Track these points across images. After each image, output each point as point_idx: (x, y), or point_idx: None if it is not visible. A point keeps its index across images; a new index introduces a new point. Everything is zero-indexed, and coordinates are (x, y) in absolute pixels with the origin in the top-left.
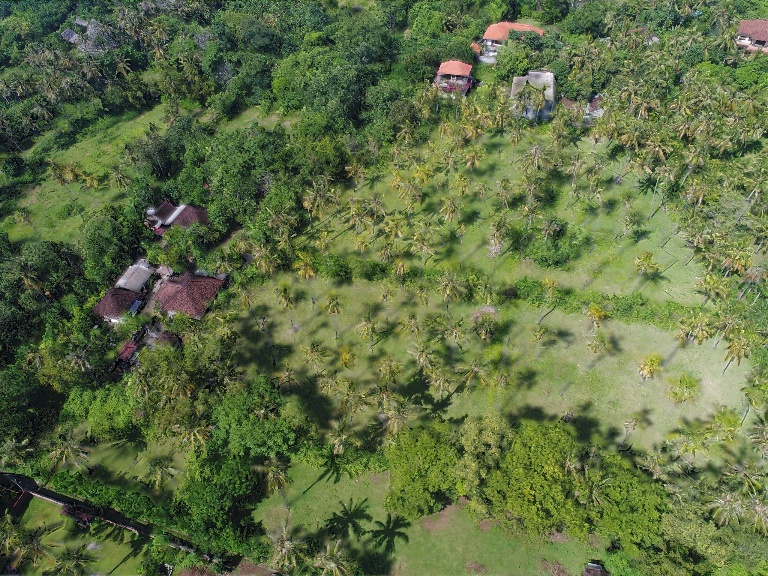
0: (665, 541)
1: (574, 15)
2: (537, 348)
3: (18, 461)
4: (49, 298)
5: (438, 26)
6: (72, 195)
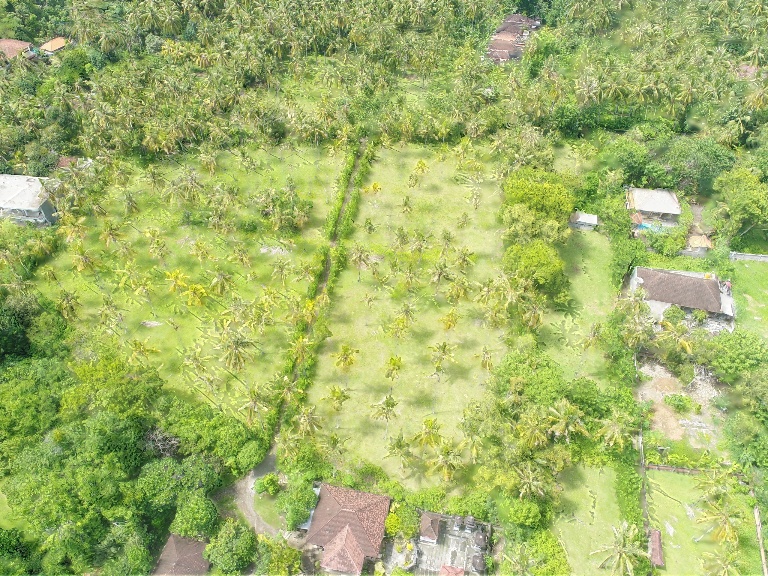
0: None
1: None
2: (390, 232)
3: None
4: None
5: None
6: None
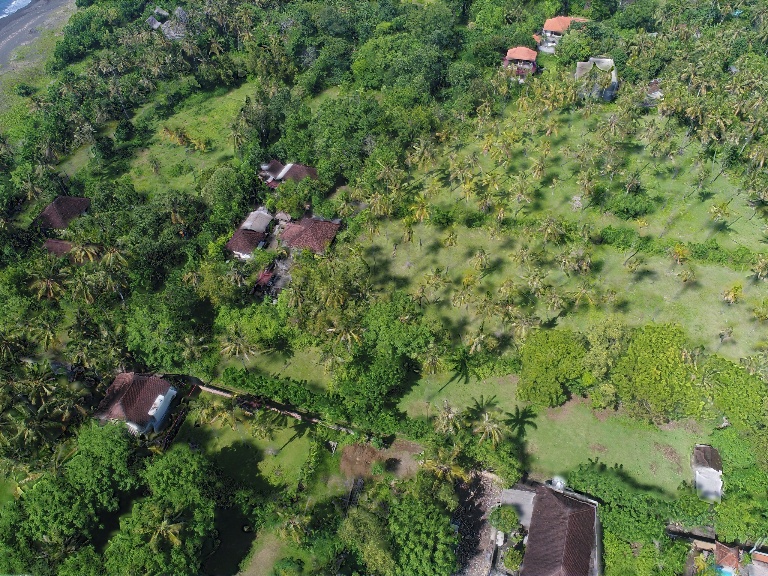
0: (767, 420)
1: (624, 12)
2: (626, 284)
3: (197, 355)
4: (182, 237)
5: (499, 19)
6: (179, 157)
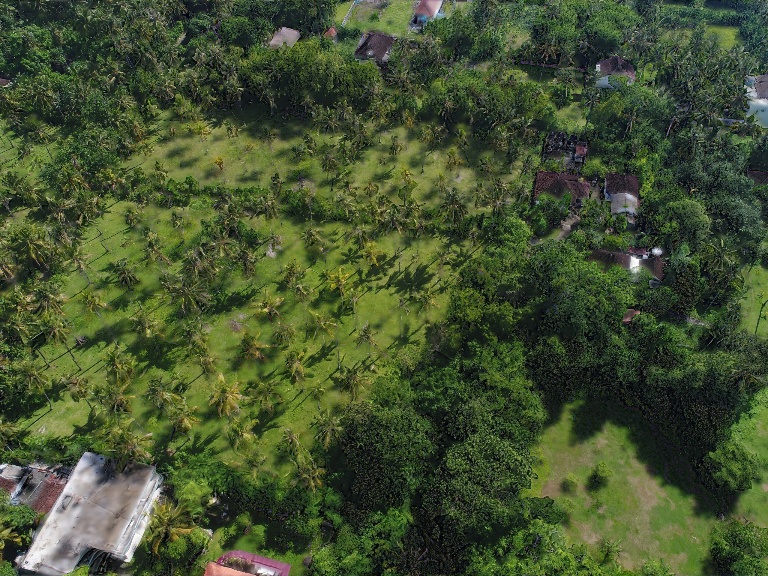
0: None
1: None
2: (268, 174)
3: None
4: None
5: None
6: None
